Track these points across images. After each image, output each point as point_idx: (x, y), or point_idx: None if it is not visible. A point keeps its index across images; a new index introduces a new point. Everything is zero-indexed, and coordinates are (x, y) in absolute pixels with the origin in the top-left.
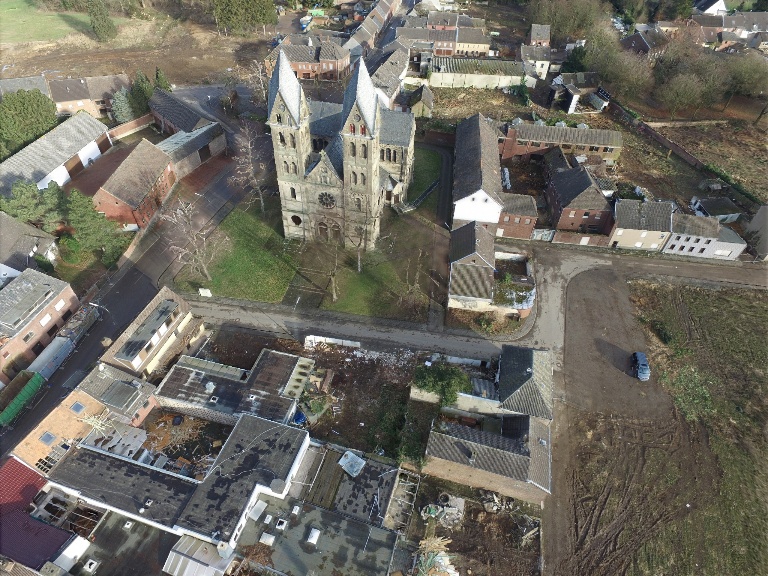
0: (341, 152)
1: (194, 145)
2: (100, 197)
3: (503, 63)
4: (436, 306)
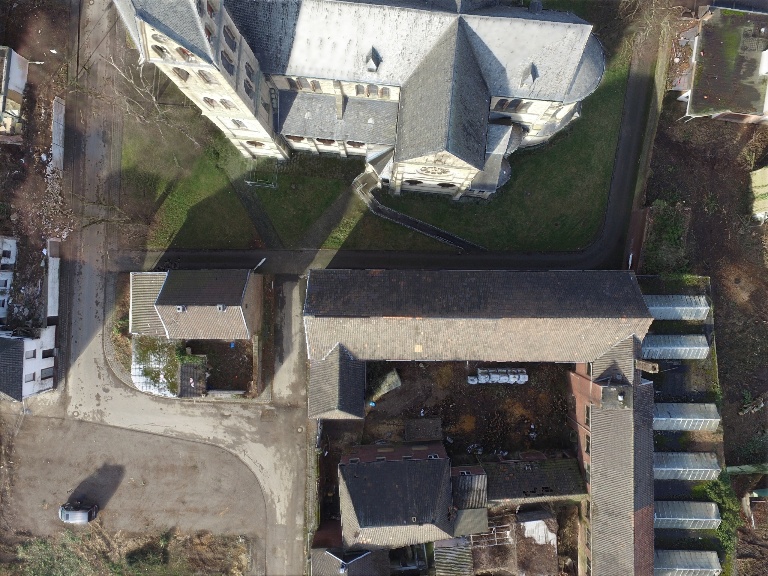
0: (268, 20)
1: None
2: None
3: None
4: (151, 260)
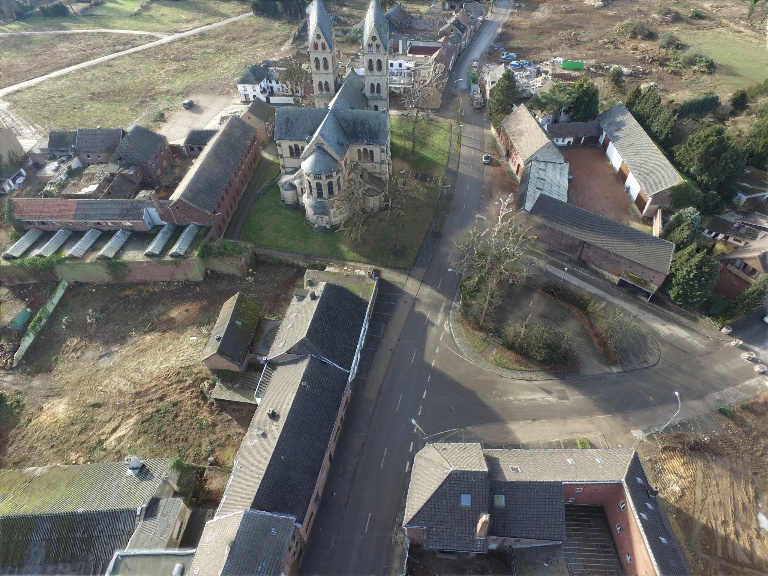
0: None
1: None
2: None
3: None
4: None
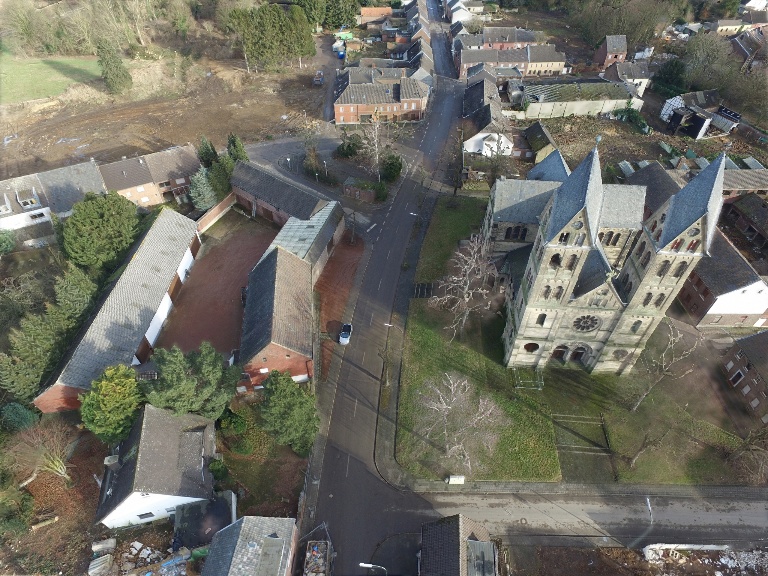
0: (602, 258)
1: (323, 239)
2: (268, 352)
3: (604, 85)
4: (762, 453)
